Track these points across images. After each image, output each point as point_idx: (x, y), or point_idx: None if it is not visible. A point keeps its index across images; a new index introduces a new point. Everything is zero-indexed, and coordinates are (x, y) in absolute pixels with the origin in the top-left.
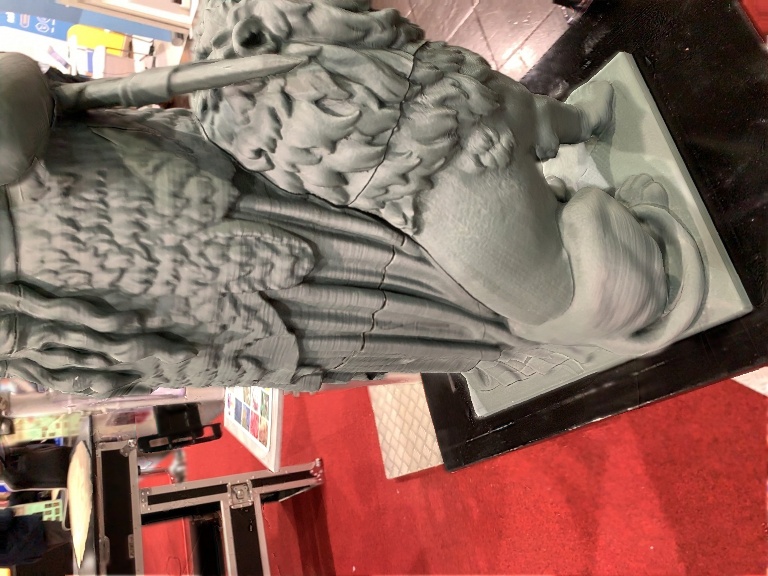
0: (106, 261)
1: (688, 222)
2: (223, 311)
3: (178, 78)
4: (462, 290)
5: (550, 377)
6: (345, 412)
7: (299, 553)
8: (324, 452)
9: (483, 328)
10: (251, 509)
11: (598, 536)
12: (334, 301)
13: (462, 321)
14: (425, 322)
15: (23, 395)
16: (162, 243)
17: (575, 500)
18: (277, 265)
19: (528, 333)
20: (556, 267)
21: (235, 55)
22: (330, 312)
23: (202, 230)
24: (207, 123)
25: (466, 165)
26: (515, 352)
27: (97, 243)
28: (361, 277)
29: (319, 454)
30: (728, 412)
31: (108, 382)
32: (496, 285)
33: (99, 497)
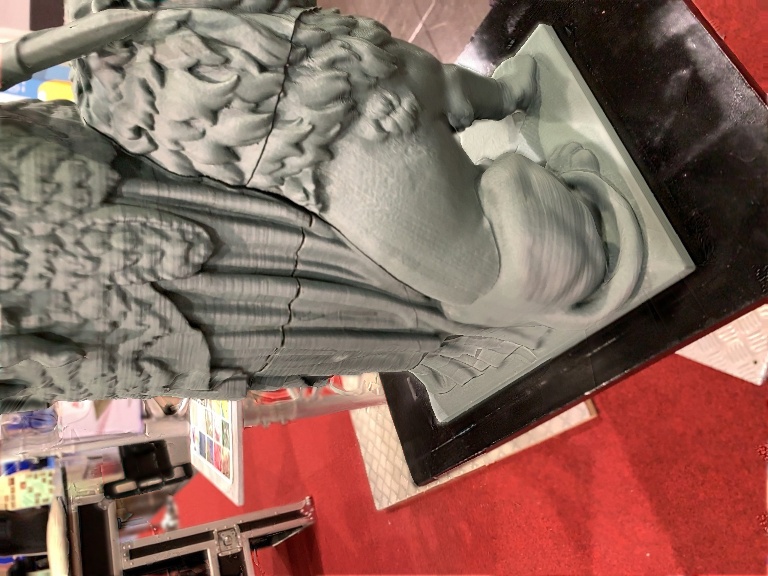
0: None
1: (621, 186)
2: (110, 306)
3: (26, 47)
4: (384, 272)
5: (504, 369)
6: (331, 445)
7: None
8: (314, 489)
9: (414, 314)
10: (240, 555)
11: (592, 548)
12: (241, 291)
13: (390, 307)
14: (349, 310)
15: None
16: (31, 232)
17: (566, 512)
18: (168, 252)
19: (463, 315)
20: (478, 236)
21: None
22: (239, 304)
23: (77, 217)
24: (83, 106)
25: (366, 132)
26: (464, 345)
27: None
28: (270, 264)
29: (309, 492)
30: (708, 401)
31: None
32: (416, 261)
33: (77, 555)
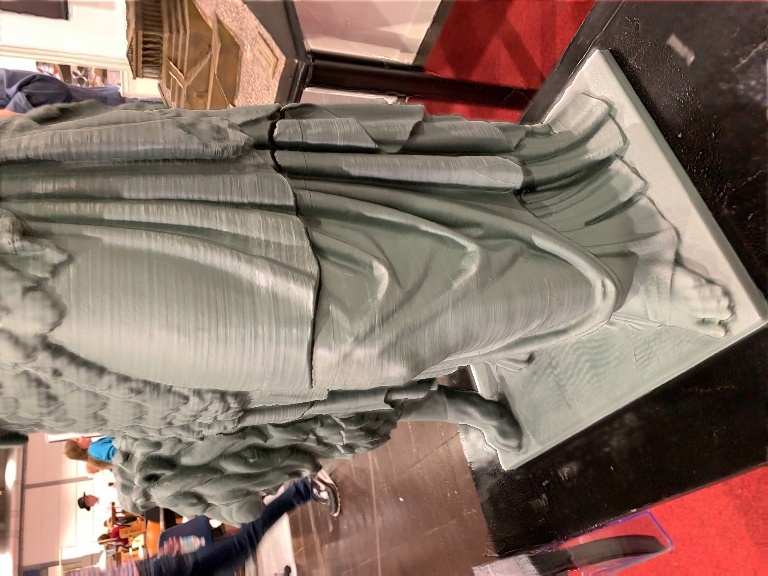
0: None
1: None
2: None
3: None
4: None
5: None
6: None
7: None
8: None
9: None
10: None
11: None
12: None
13: None
14: None
15: None
16: None
17: None
18: None
19: None
20: None
21: None
22: None
23: None
24: None
25: None
26: None
27: None
28: None
29: None
30: None
31: None
32: None
33: None
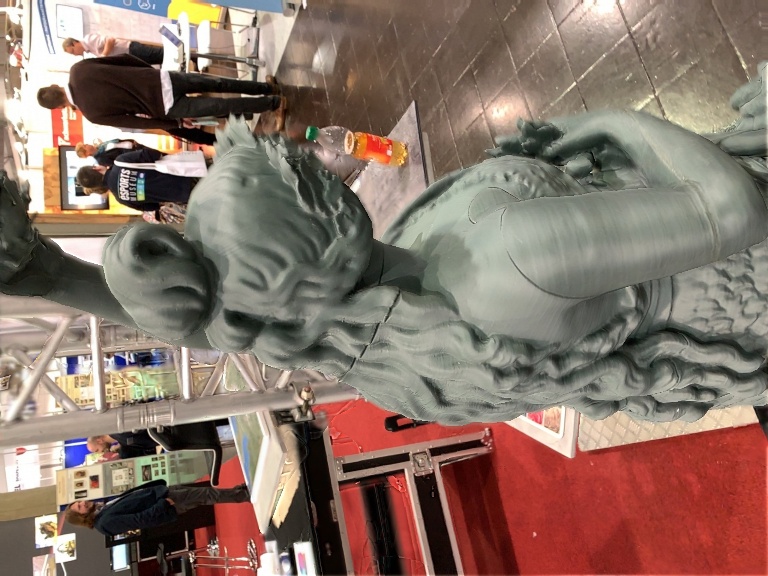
0: (746, 307)
1: None
2: None
3: None
4: None
5: None
6: None
7: (463, 516)
8: None
9: None
10: (432, 476)
11: None
12: None
13: None
14: None
15: (317, 384)
16: None
17: None
18: None
19: None
20: None
21: None
22: None
23: None
24: None
25: None
26: None
27: (743, 291)
28: None
29: (488, 424)
30: None
31: (699, 412)
32: None
33: (304, 466)
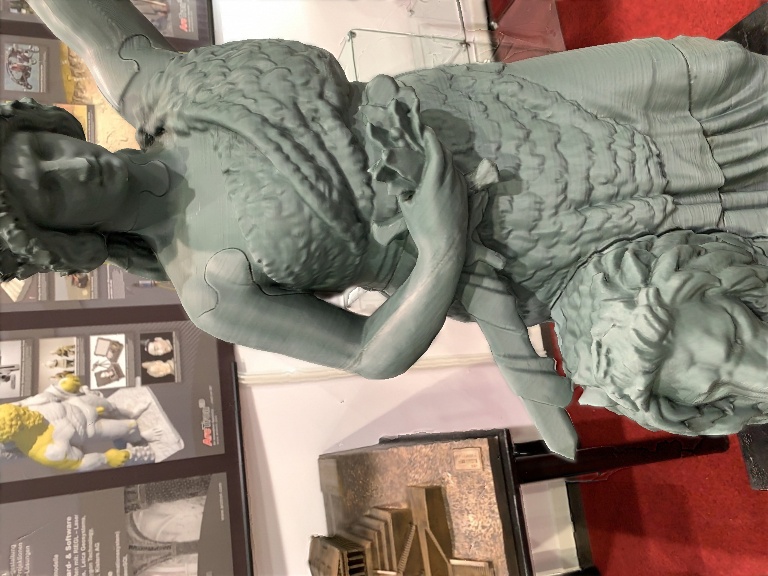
0: None
1: None
2: None
3: None
4: None
5: None
6: None
7: None
8: None
9: None
10: None
11: None
12: None
13: None
14: None
15: None
16: None
17: None
18: None
19: None
20: None
21: (584, 386)
22: None
23: None
24: (555, 318)
25: None
26: None
27: None
28: None
29: None
30: None
31: None
32: None
33: None
